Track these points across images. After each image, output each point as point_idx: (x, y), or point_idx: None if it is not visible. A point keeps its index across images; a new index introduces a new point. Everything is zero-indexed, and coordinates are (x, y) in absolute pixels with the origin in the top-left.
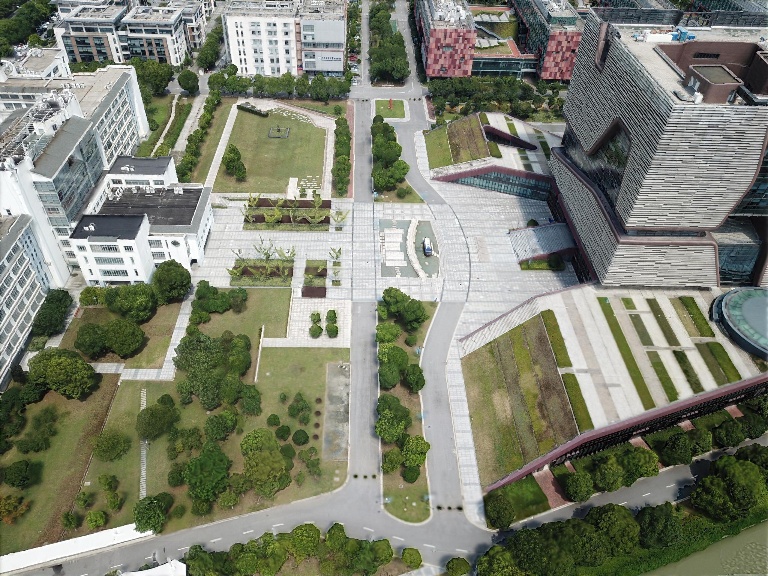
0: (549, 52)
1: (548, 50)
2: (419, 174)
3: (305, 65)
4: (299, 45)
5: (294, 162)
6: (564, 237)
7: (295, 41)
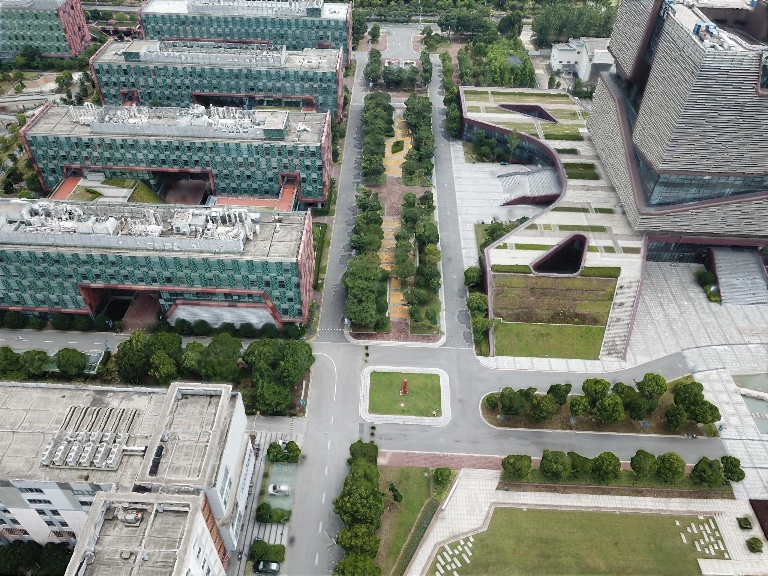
0: (325, 167)
1: (325, 166)
2: (617, 374)
3: (235, 540)
4: (213, 532)
5: (643, 568)
6: (734, 256)
7: (210, 537)
